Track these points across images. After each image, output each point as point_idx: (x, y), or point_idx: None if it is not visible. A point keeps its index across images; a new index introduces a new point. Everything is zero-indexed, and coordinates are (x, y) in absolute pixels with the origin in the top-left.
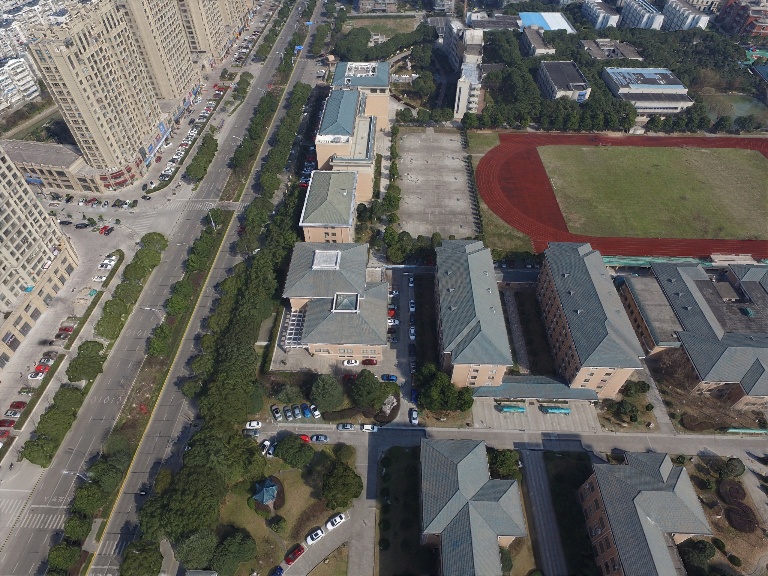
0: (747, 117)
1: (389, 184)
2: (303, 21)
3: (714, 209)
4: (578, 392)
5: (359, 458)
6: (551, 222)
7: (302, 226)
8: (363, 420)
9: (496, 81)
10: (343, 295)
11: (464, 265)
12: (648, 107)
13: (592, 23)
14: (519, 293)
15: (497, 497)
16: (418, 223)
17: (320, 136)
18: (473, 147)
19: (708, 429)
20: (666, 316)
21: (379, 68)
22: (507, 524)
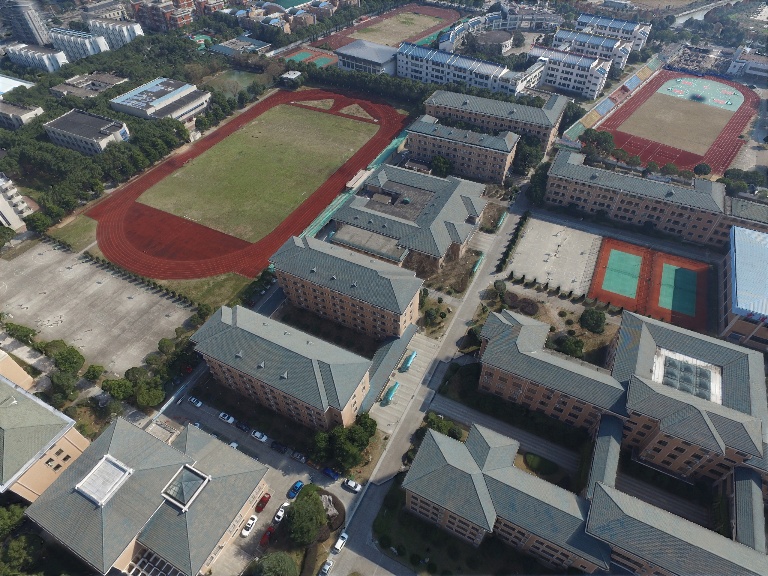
0: (253, 85)
1: (31, 349)
2: None
3: (308, 157)
4: (406, 335)
5: (367, 572)
6: (231, 248)
7: (6, 489)
8: (327, 546)
9: (13, 169)
10: (171, 485)
11: (245, 336)
12: (183, 114)
13: (41, 69)
14: (286, 317)
15: (486, 446)
16: (122, 352)
17: None
18: (75, 243)
19: (467, 281)
20: (381, 241)
21: None
22: (508, 452)
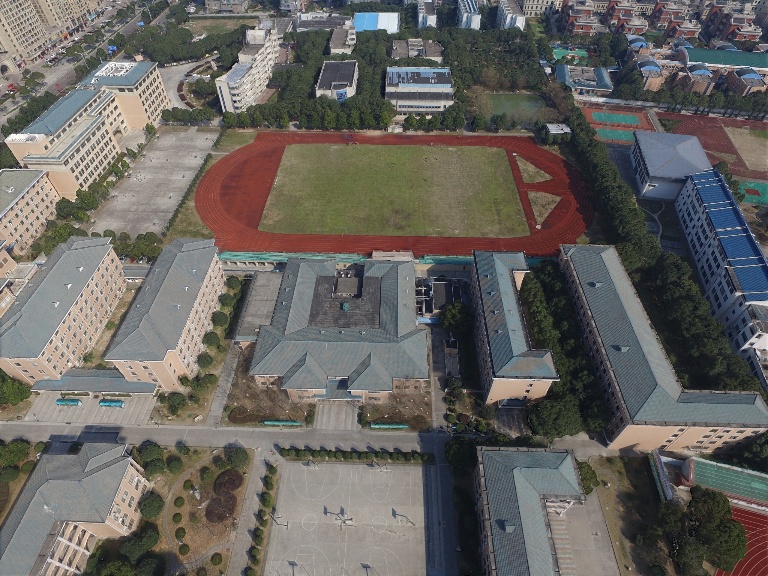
0: (499, 115)
1: None
2: (143, 22)
3: (417, 206)
4: (135, 385)
5: None
6: (246, 219)
7: None
8: None
9: (282, 80)
10: None
11: (56, 261)
12: (411, 106)
13: (415, 23)
14: None
15: None
16: (114, 220)
17: (15, 135)
18: (223, 146)
19: (251, 422)
20: (264, 311)
21: (136, 68)
22: None
